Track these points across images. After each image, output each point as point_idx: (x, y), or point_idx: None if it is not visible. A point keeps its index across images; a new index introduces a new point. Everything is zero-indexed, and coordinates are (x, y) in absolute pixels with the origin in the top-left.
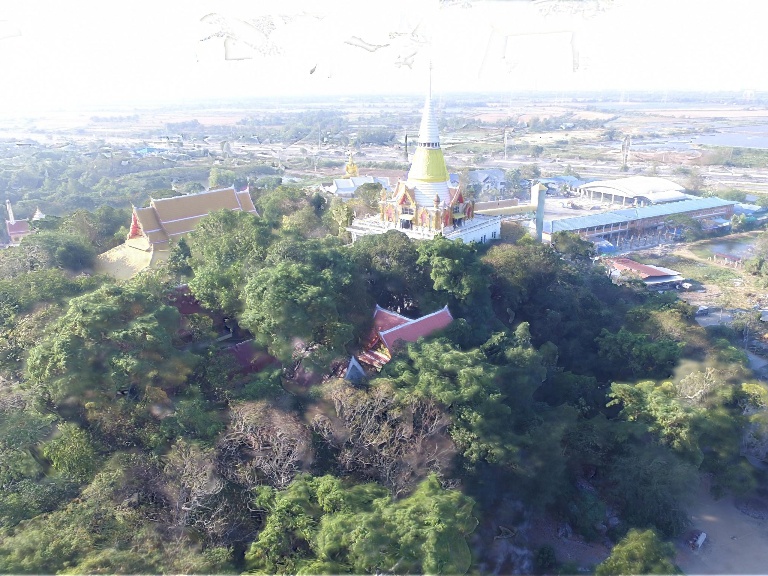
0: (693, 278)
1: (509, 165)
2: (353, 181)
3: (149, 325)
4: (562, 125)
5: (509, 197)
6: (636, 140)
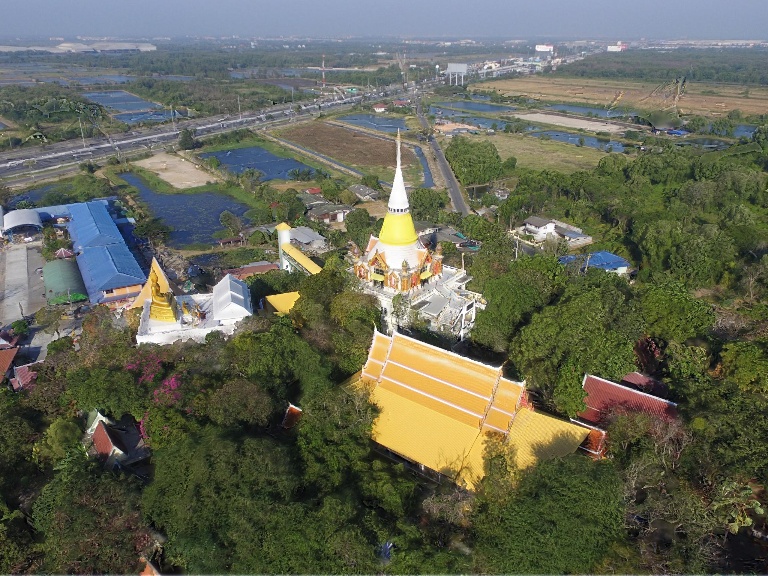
0: None
1: None
2: (237, 293)
3: (765, 339)
4: None
5: None
6: None
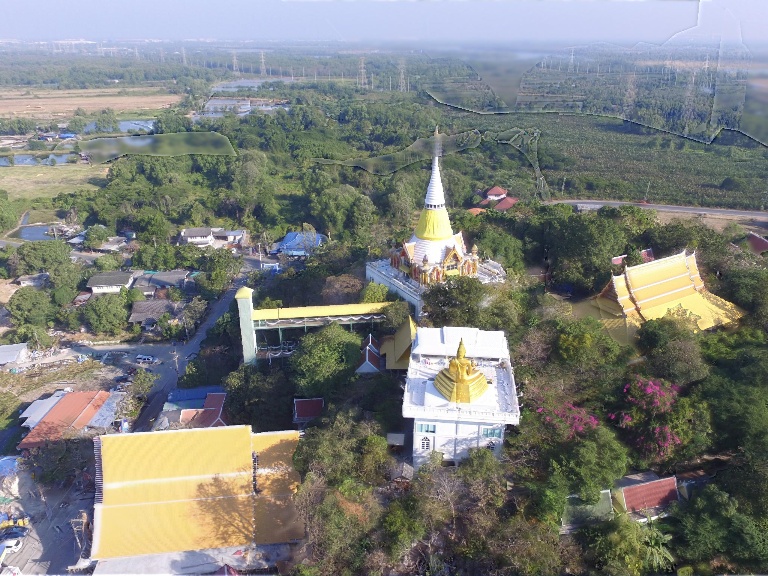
0: (11, 412)
1: None
2: None
3: None
4: None
5: None
6: None
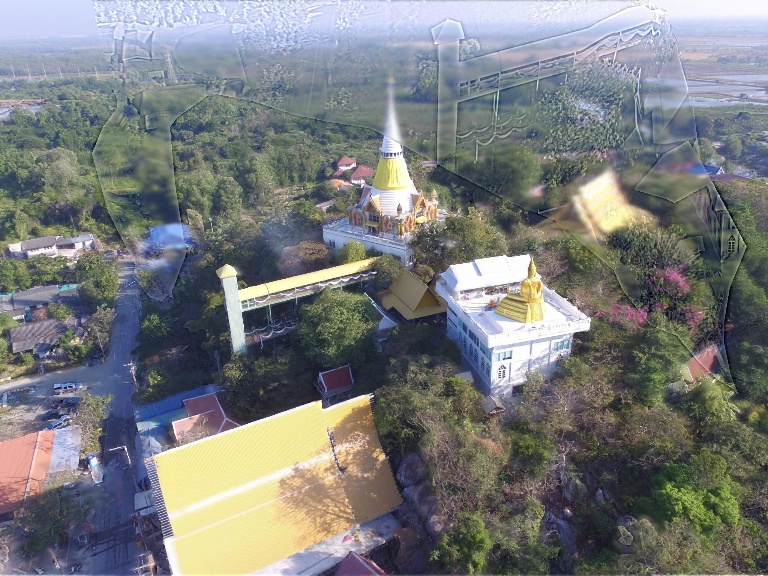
0: None
1: None
2: None
3: None
4: None
5: None
6: None
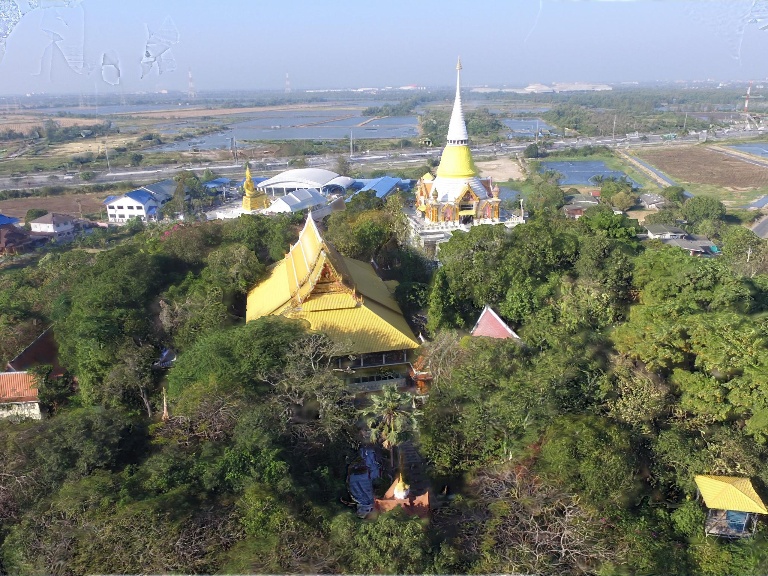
0: None
1: (122, 177)
2: (296, 196)
3: None
4: (80, 133)
5: (209, 206)
6: (179, 141)
